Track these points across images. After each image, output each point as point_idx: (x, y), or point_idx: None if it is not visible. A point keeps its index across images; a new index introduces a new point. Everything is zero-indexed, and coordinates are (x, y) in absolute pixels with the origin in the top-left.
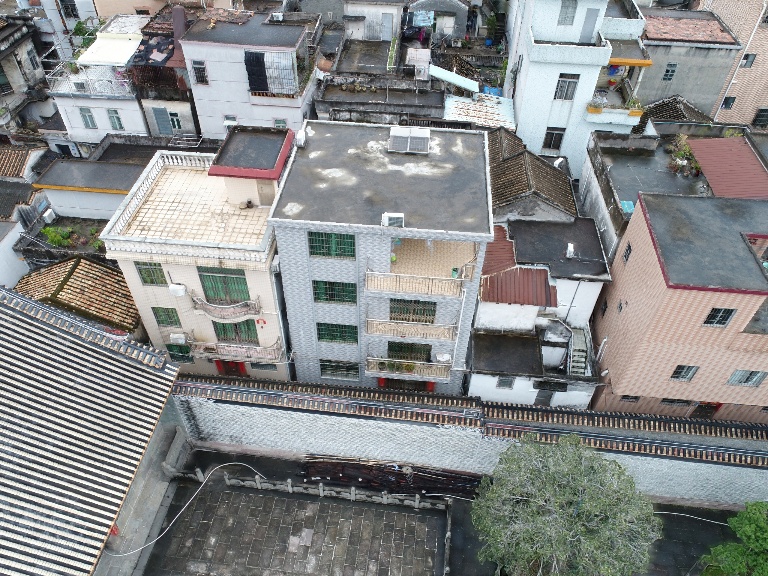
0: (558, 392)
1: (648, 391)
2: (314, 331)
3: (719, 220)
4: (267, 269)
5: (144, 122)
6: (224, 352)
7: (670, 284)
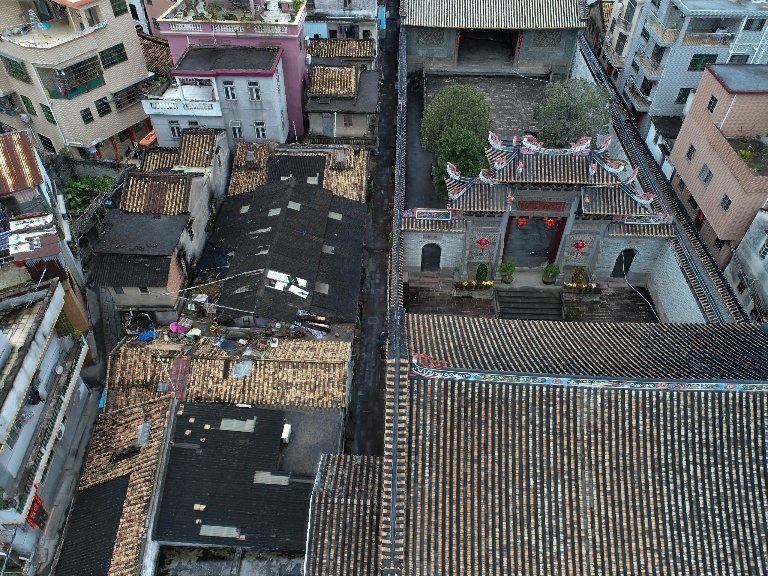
0: (665, 160)
1: None
2: (633, 57)
3: None
4: (638, 2)
5: None
6: None
7: None
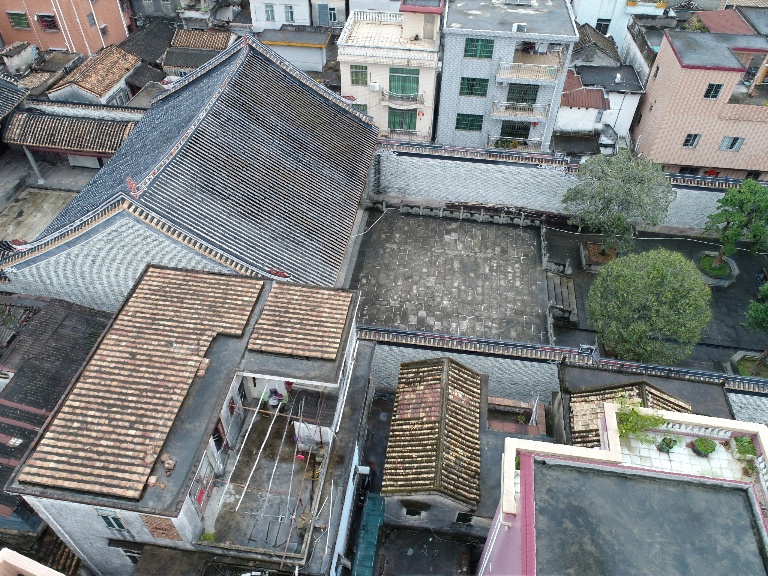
0: None
1: (668, 158)
2: (454, 121)
3: (715, 42)
4: None
5: (309, 16)
6: (395, 136)
7: (684, 65)
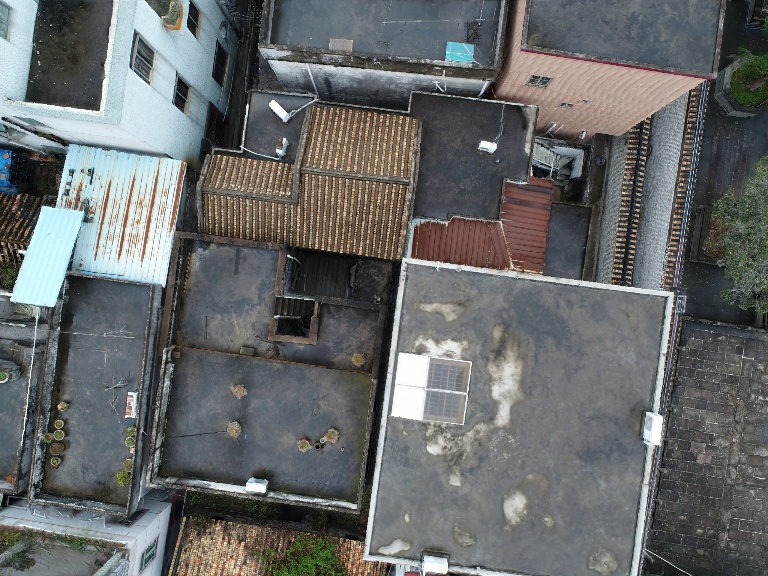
0: None
1: None
2: None
3: None
4: None
5: None
6: None
7: None
